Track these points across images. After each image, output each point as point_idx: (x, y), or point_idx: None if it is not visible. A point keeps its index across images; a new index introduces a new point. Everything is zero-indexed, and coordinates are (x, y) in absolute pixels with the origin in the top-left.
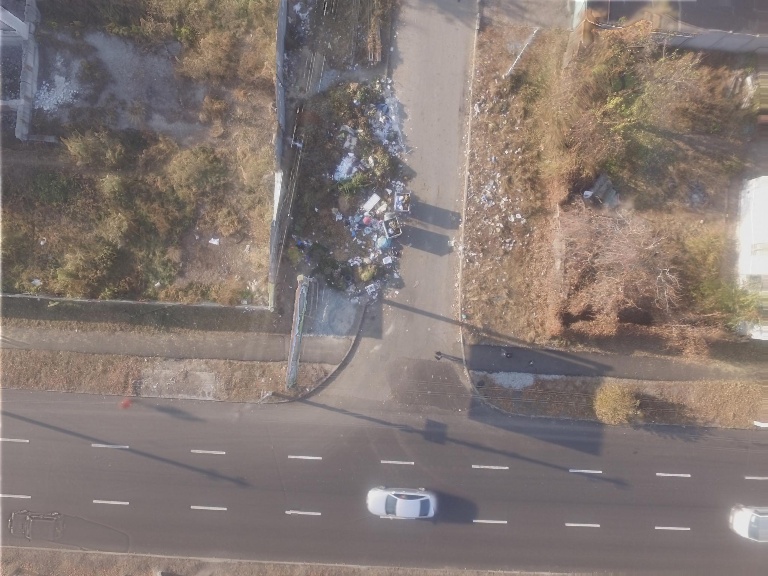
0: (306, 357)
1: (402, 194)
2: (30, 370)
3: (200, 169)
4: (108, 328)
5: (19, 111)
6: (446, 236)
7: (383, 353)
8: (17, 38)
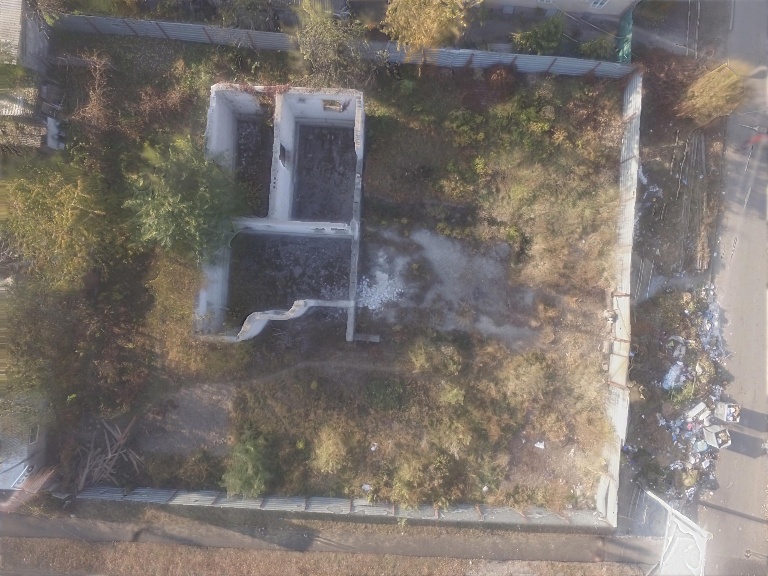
0: (624, 558)
1: (732, 406)
2: (357, 574)
3: (537, 379)
4: (434, 531)
5: (350, 313)
6: (760, 439)
7: (696, 552)
8: (344, 236)
